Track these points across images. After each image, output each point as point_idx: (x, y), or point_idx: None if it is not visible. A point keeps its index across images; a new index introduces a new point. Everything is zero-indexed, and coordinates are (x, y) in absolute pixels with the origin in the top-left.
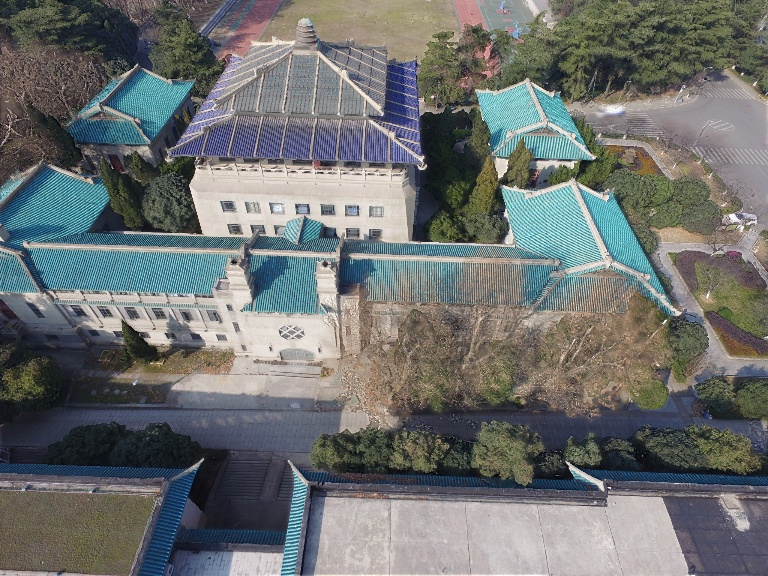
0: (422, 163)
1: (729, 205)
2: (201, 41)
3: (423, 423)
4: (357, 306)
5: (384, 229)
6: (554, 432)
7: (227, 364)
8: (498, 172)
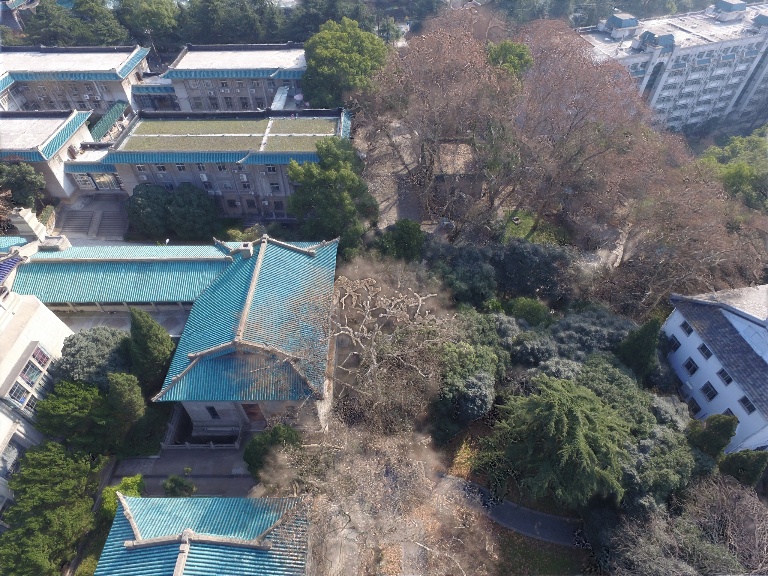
0: None
1: None
2: None
3: None
4: None
5: None
6: None
7: None
8: None
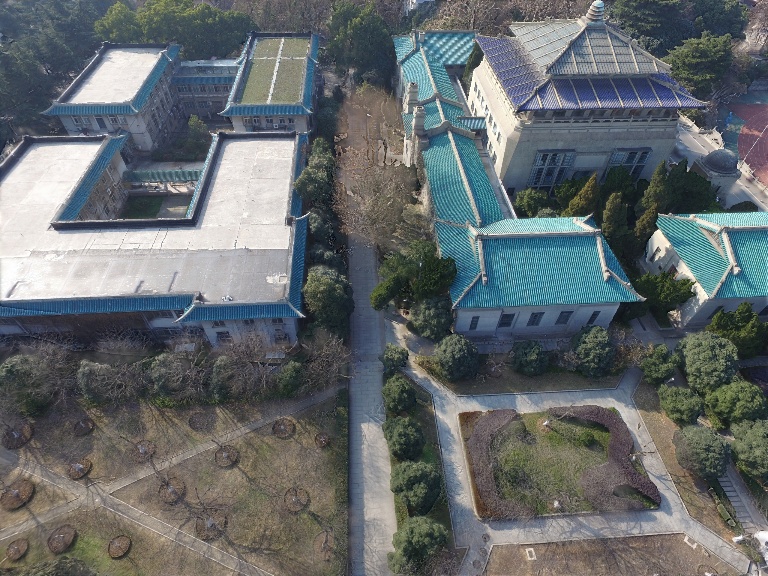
0: (516, 110)
1: None
2: (720, 55)
3: None
4: (417, 150)
5: (497, 157)
6: (362, 275)
7: (397, 153)
8: (651, 241)
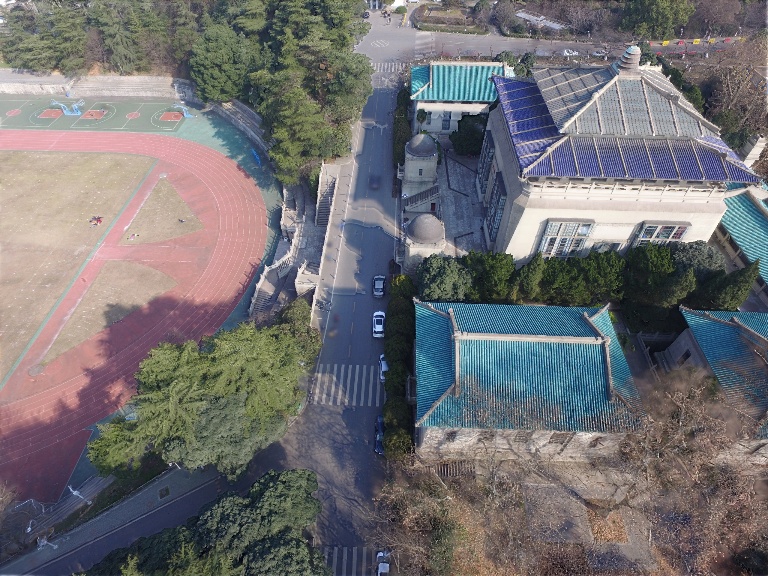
0: None
1: None
2: None
3: None
4: None
5: None
6: None
7: None
8: None
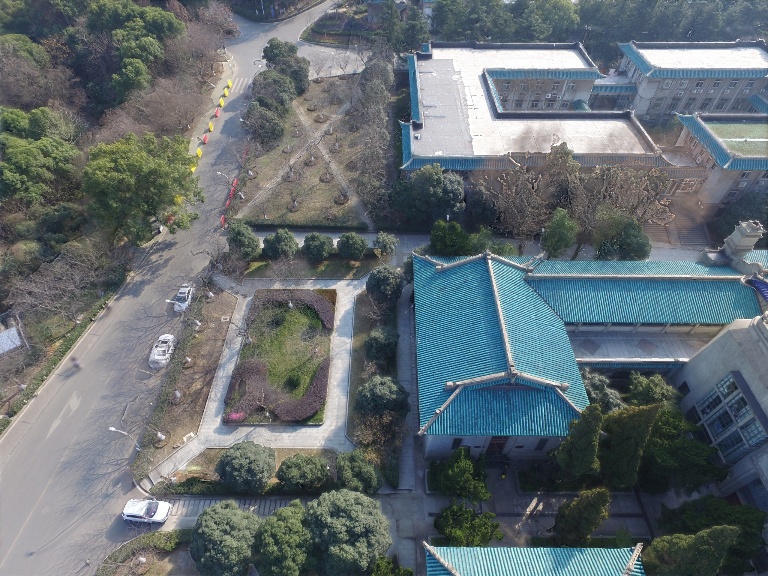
0: None
1: (124, 569)
2: None
3: (589, 258)
4: None
5: None
6: None
7: None
8: None
